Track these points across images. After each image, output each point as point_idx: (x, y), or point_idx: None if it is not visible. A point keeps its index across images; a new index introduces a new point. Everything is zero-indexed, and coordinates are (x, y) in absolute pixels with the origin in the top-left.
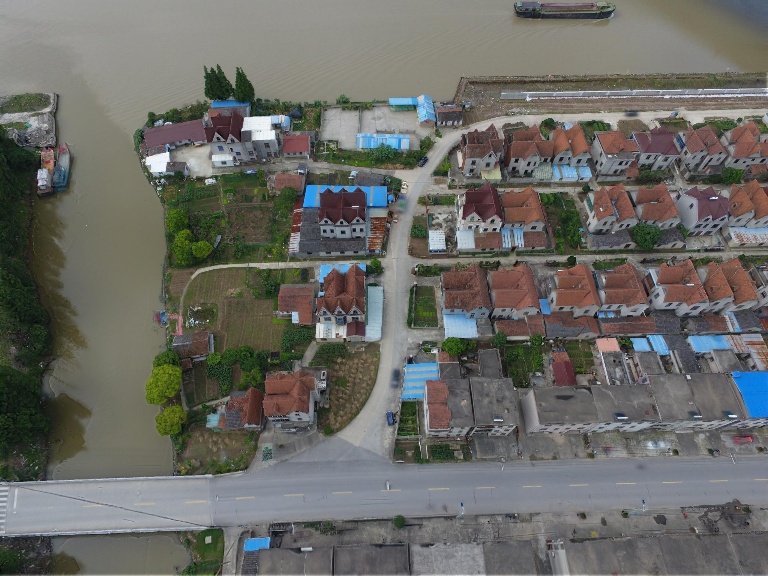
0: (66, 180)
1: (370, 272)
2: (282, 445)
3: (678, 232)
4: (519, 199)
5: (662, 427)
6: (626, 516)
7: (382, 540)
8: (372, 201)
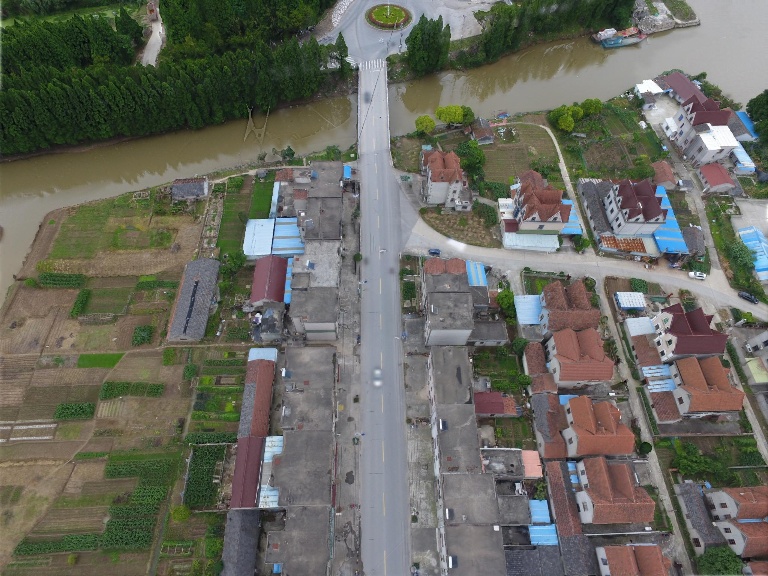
0: (611, 46)
1: (575, 241)
2: (412, 187)
3: None
4: (718, 379)
5: None
6: (354, 440)
7: (347, 248)
8: (663, 239)
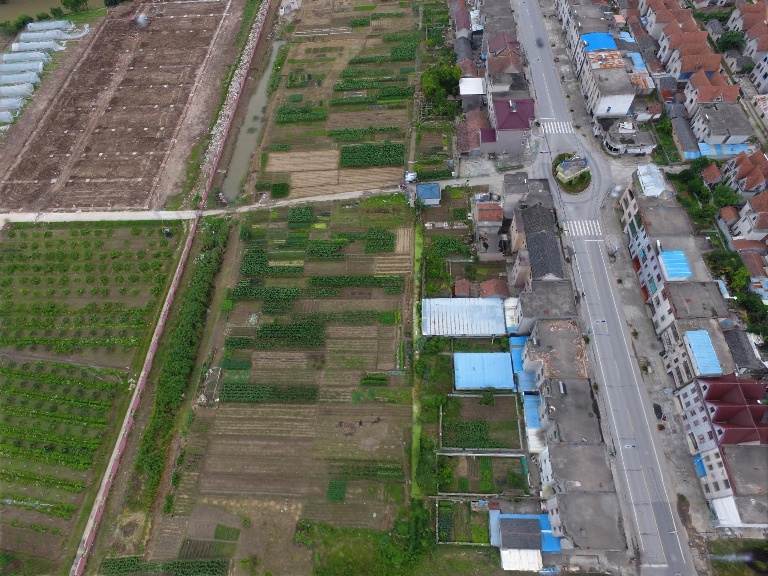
0: None
1: None
2: None
3: (748, 62)
4: None
5: (567, 28)
6: (515, 22)
7: None
8: None
